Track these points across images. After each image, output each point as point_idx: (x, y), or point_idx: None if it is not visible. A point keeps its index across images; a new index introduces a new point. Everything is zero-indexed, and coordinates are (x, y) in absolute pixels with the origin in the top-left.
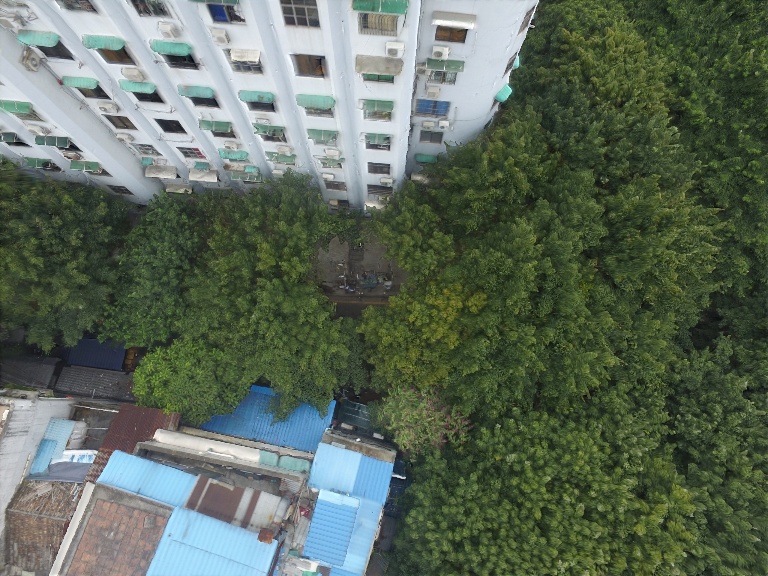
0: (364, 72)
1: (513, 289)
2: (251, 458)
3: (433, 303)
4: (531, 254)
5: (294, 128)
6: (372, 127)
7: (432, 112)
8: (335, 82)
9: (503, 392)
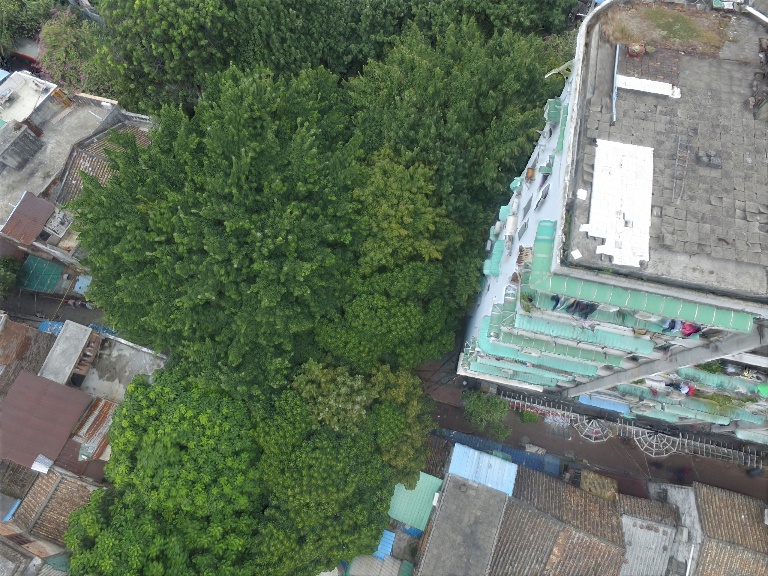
0: None
1: None
2: None
3: None
4: None
5: None
6: None
7: None
8: None
9: None
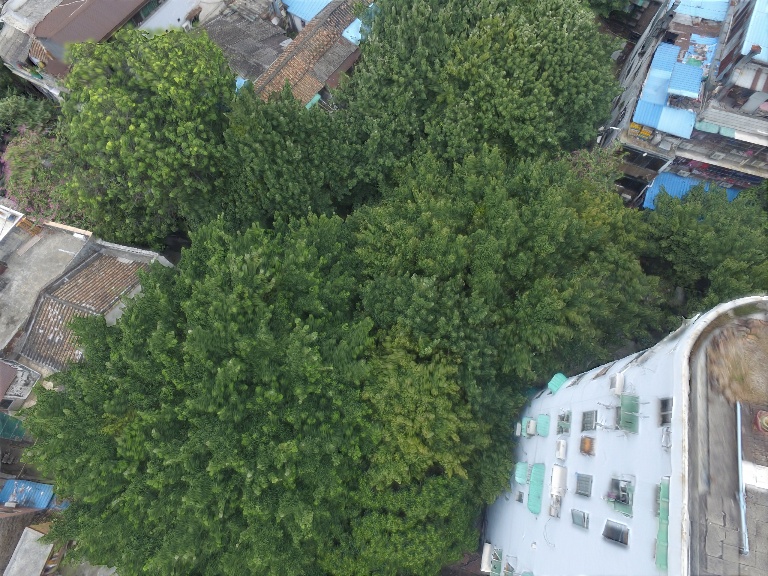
0: None
1: None
2: (740, 135)
3: (608, 217)
4: None
5: None
6: None
7: None
8: None
9: None
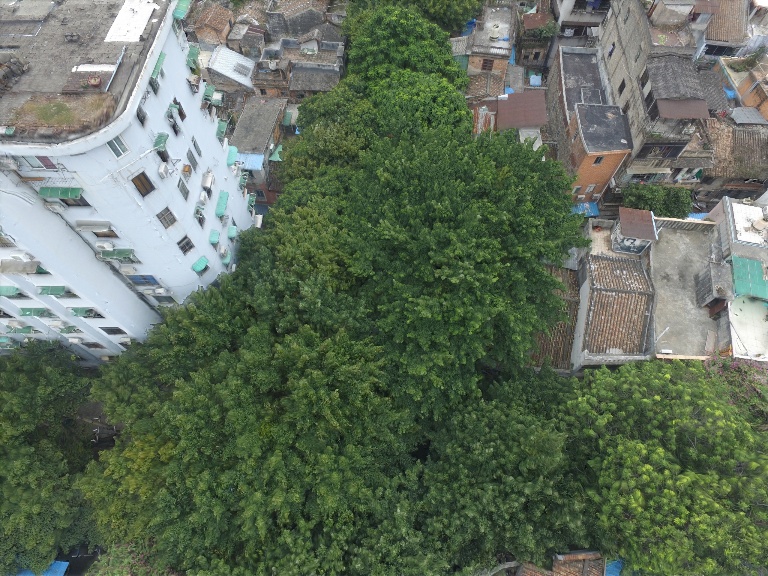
0: (6, 272)
1: (181, 438)
2: None
3: (125, 456)
4: (195, 404)
5: (13, 307)
6: (72, 303)
7: (146, 282)
8: (8, 276)
9: (193, 540)
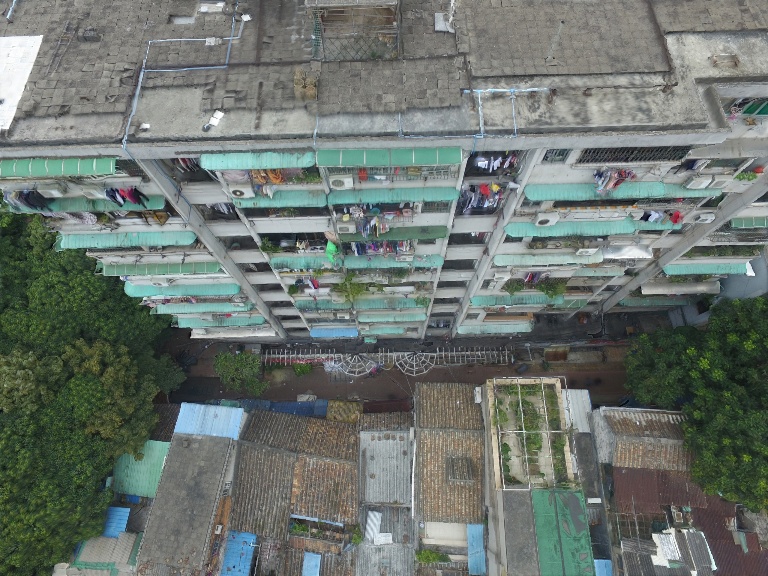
0: None
1: None
2: None
3: None
4: None
5: None
6: None
7: None
8: None
9: None
